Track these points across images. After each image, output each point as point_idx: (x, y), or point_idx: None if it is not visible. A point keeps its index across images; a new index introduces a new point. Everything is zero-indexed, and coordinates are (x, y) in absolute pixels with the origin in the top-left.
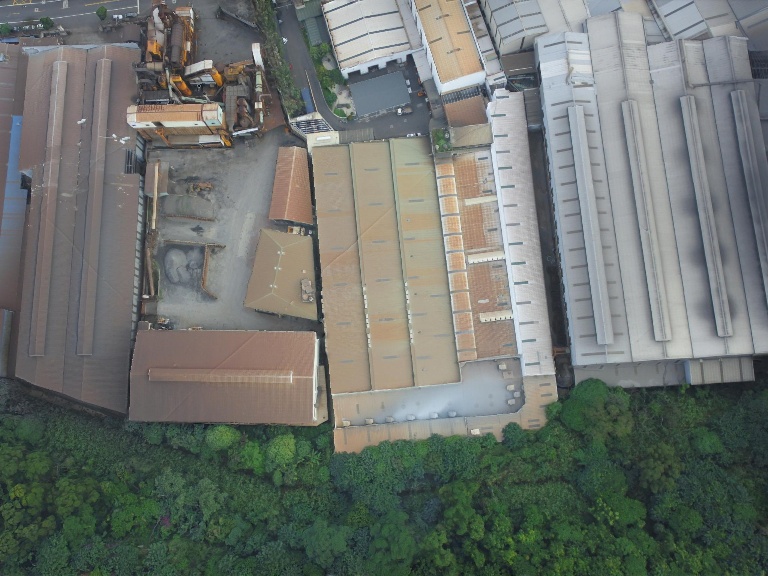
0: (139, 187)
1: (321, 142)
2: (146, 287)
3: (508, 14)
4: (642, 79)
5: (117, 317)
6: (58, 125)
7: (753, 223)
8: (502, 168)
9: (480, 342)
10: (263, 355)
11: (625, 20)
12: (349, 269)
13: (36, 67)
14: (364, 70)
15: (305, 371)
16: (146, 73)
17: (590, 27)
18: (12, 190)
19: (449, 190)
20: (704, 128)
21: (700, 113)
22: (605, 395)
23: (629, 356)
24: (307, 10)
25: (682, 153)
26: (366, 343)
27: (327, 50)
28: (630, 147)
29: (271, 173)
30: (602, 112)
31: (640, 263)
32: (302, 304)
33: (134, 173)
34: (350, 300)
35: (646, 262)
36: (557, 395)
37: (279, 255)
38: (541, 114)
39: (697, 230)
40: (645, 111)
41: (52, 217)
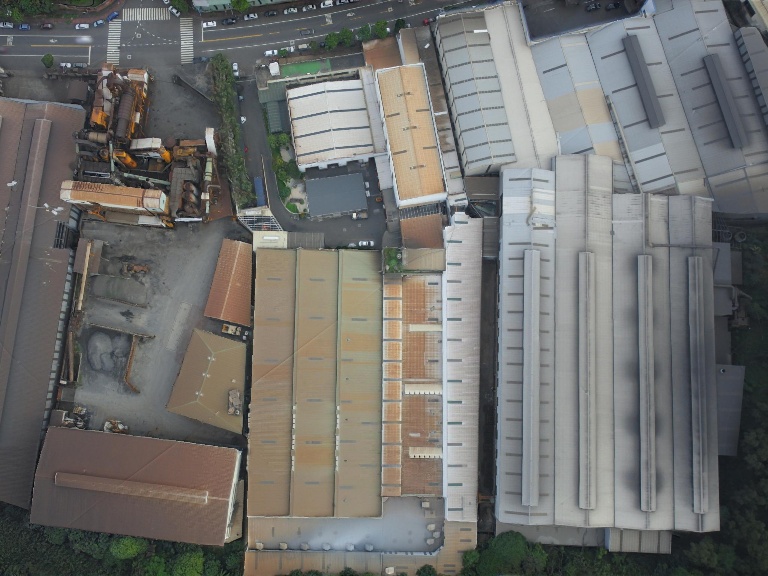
0: (68, 263)
1: (268, 242)
2: (65, 371)
3: (477, 137)
4: (603, 229)
5: (29, 405)
6: None
7: (691, 396)
8: (451, 299)
9: (406, 477)
10: (179, 470)
11: (595, 164)
12: (281, 385)
13: None
14: (323, 166)
15: (222, 492)
16: (87, 145)
17: (559, 165)
18: None
19: (394, 313)
20: (657, 290)
21: (656, 274)
22: (523, 552)
23: (552, 518)
24: (270, 92)
25: (632, 314)
26: (289, 465)
27: (286, 142)
28: (581, 302)
29: (212, 263)
30: (559, 258)
31: (575, 424)
32: (228, 416)
33: (64, 248)
34: (278, 418)
35: (581, 425)
36: (476, 542)
37: (209, 361)
38: (498, 246)
39: (636, 397)
40: (602, 264)
41: None
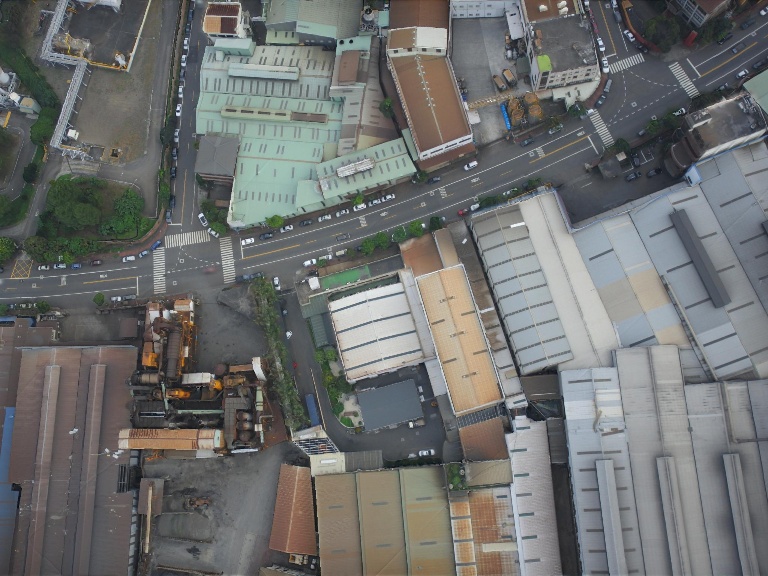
0: (132, 506)
1: (326, 465)
2: None
3: (529, 338)
4: (679, 427)
5: None
6: (49, 439)
7: None
8: (523, 515)
9: None
10: None
11: (659, 356)
12: None
13: (29, 365)
14: (373, 375)
15: None
16: (140, 389)
17: (620, 360)
18: (3, 492)
19: (464, 534)
20: (751, 491)
21: (746, 473)
22: None
23: None
24: (313, 306)
25: (726, 522)
26: None
27: (333, 357)
28: (667, 514)
29: (273, 488)
30: (634, 464)
31: None
32: None
33: (127, 491)
34: None
35: None
36: None
37: None
38: (566, 450)
39: None
40: (683, 467)
41: (39, 546)
